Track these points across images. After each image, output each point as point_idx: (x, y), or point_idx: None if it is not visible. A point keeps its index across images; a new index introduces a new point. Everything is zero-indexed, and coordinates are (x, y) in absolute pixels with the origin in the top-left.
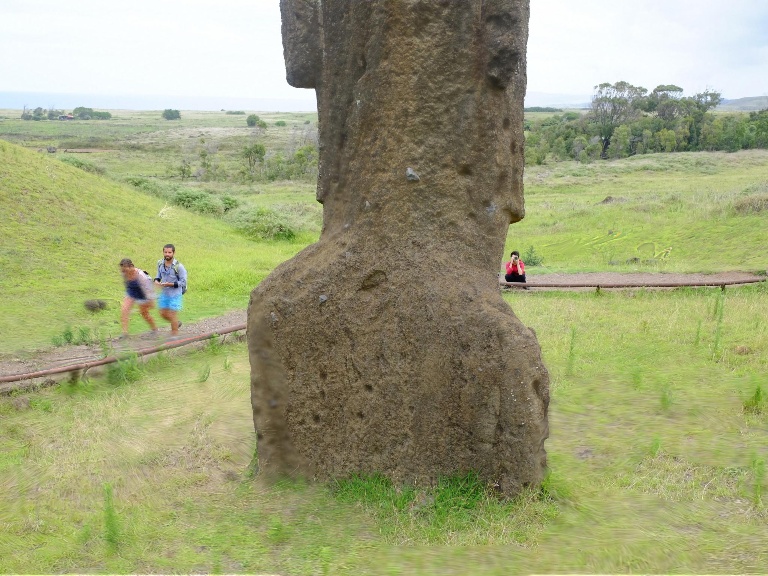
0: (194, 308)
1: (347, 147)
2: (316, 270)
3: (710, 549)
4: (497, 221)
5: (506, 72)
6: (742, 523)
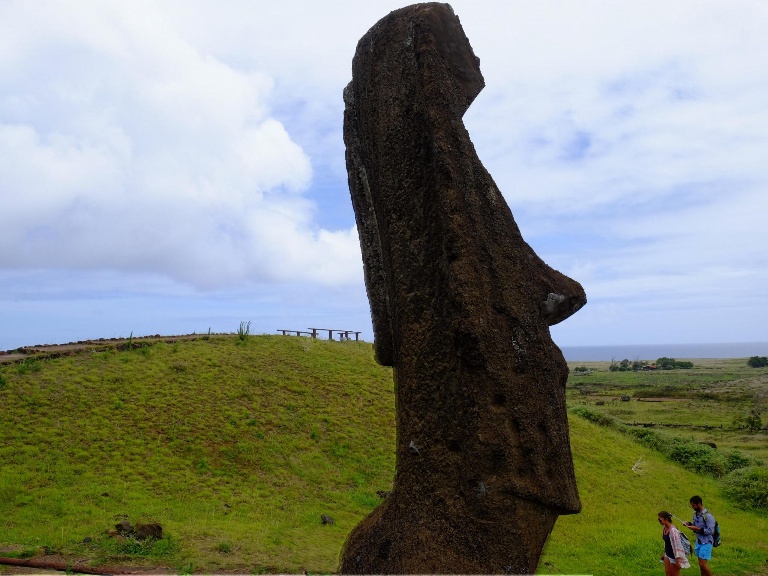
0: (566, 571)
1: None
2: (364, 531)
3: None
4: (493, 504)
5: (469, 351)
6: None
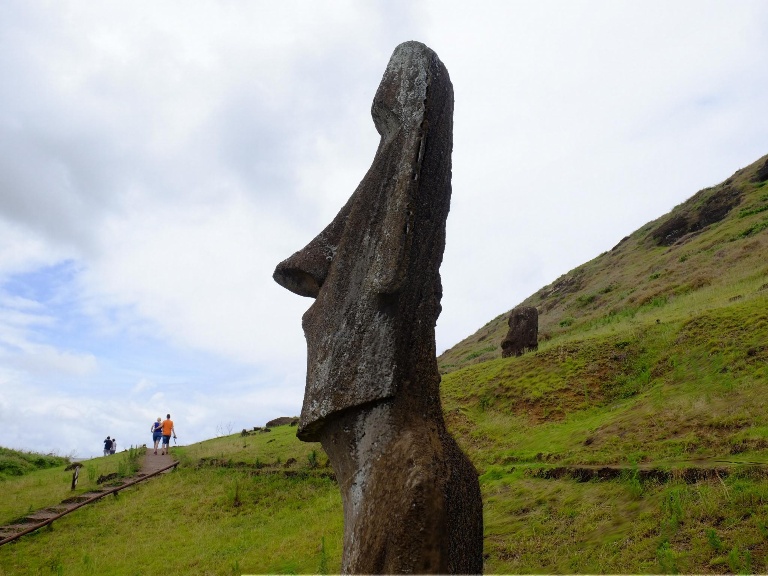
0: None
1: (414, 353)
2: (441, 451)
3: (531, 567)
4: None
5: None
6: (498, 567)
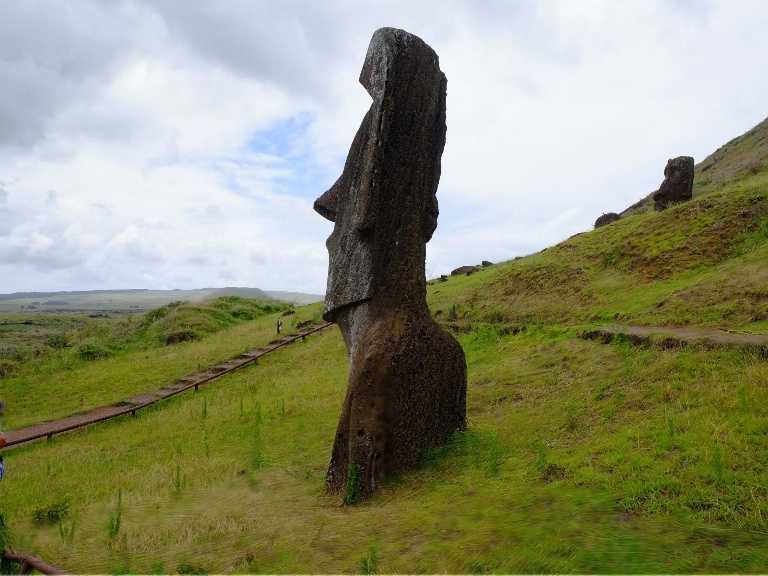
0: None
1: (391, 267)
2: (401, 334)
3: None
4: None
5: None
6: None
